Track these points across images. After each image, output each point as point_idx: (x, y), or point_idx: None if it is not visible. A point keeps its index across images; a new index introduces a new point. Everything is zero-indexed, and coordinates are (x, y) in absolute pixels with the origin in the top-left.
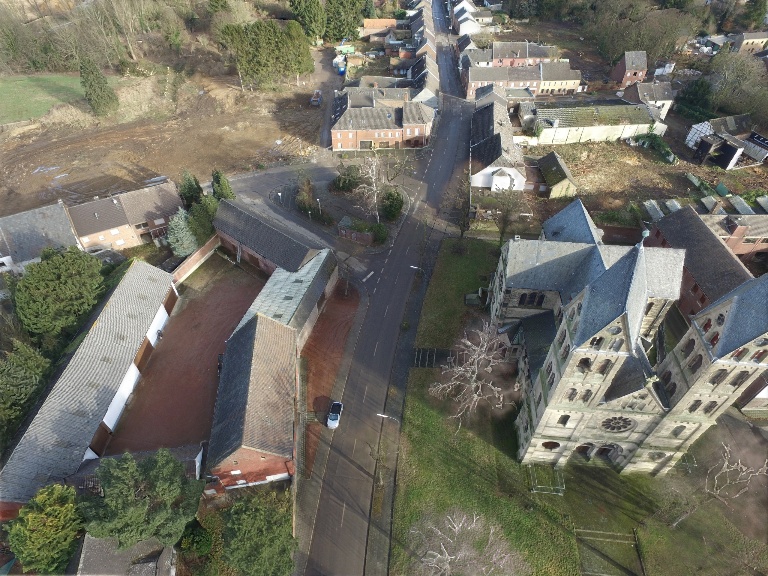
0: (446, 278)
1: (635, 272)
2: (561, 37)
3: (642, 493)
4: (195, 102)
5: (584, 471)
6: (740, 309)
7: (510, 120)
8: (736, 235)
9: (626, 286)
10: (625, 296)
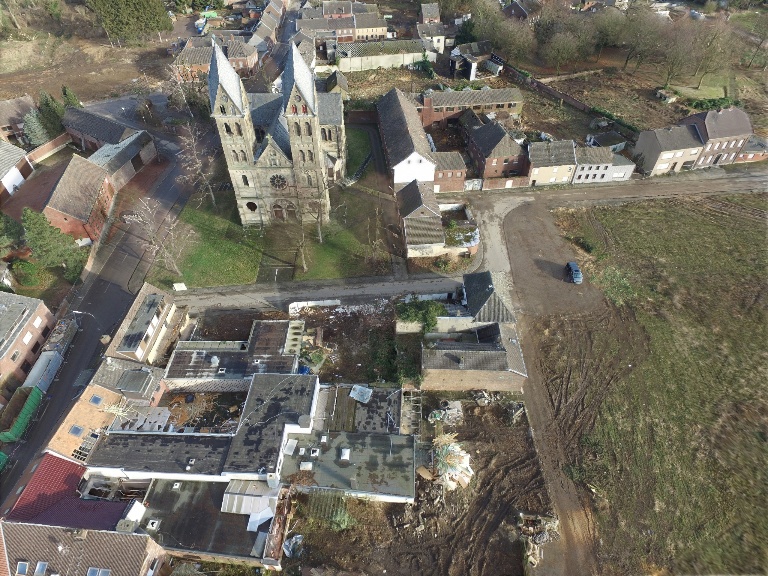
0: None
1: (217, 59)
2: (396, 1)
3: (311, 232)
4: (69, 57)
5: (281, 226)
6: (284, 82)
7: (320, 55)
8: (427, 105)
9: (217, 68)
10: (218, 74)
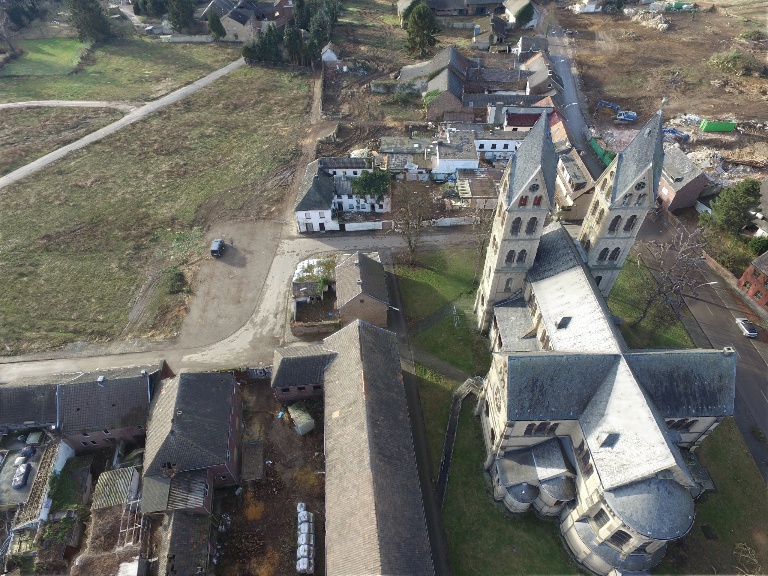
0: (766, 534)
1: None
2: None
3: None
4: None
5: None
6: None
7: None
8: None
9: None
10: None
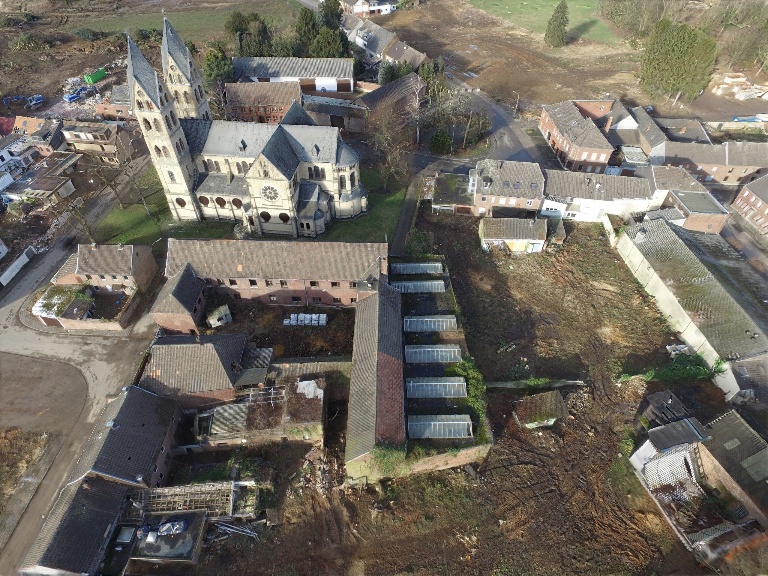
0: None
1: None
2: None
3: None
4: (598, 70)
5: None
6: None
7: None
8: None
9: None
10: None
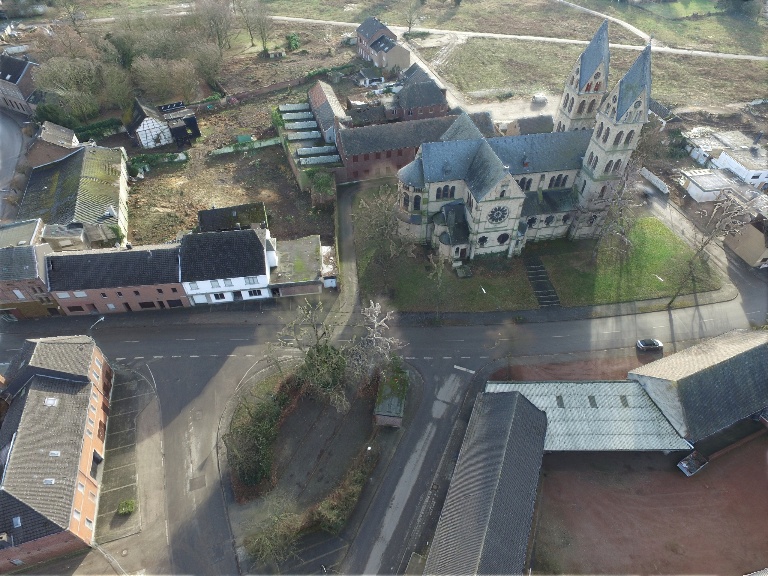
0: None
1: None
2: None
3: None
4: None
5: None
6: None
7: None
8: None
9: None
10: None
